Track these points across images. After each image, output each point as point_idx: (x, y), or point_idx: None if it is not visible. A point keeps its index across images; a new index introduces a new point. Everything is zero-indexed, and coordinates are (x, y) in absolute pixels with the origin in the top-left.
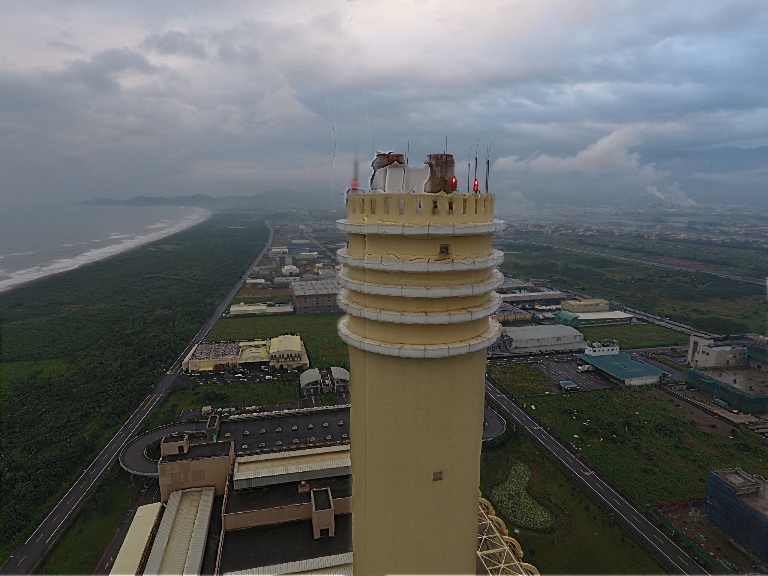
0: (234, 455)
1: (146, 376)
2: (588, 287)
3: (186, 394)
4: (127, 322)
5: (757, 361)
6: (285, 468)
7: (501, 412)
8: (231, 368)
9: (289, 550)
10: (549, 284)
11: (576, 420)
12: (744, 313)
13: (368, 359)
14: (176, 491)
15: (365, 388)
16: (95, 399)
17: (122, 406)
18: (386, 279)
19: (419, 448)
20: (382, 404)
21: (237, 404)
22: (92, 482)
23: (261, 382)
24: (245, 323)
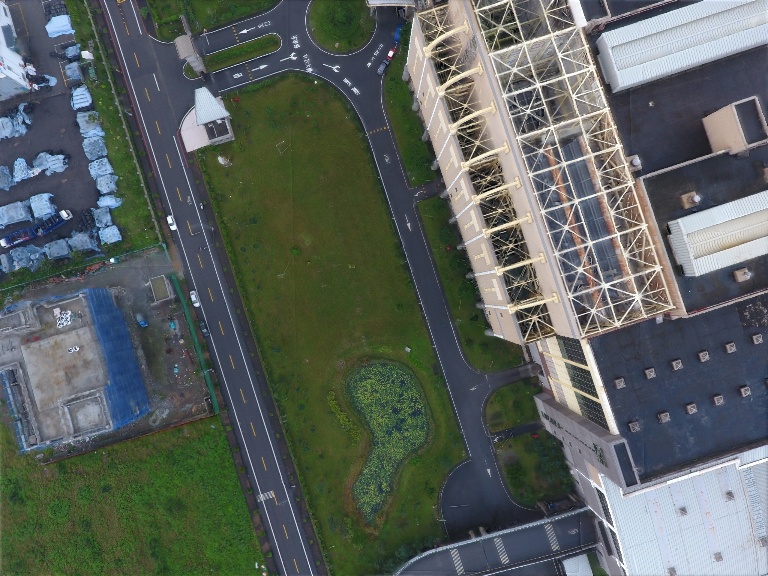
0: None
1: None
2: None
3: None
4: None
5: None
6: None
7: None
8: None
9: (750, 94)
10: None
11: None
12: None
13: None
14: None
15: None
16: None
17: None
18: None
19: None
20: None
21: None
22: None
23: None
24: None
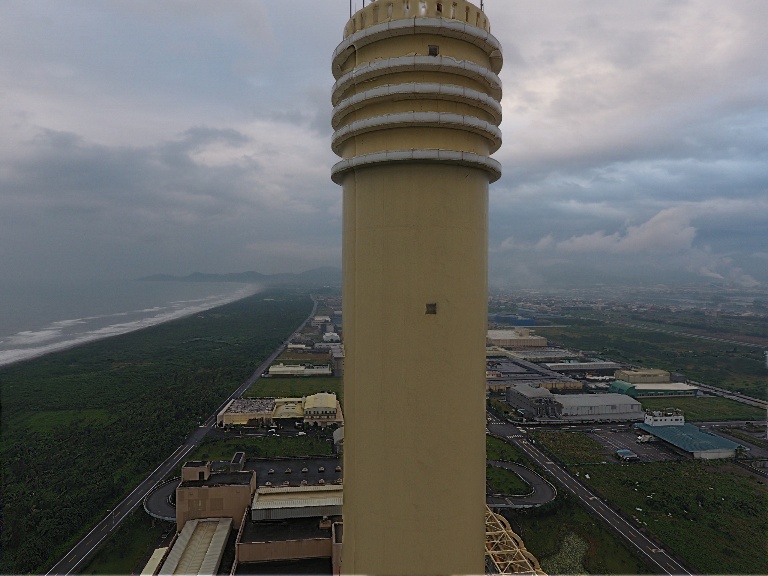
0: (255, 488)
1: (181, 427)
2: (645, 360)
3: (218, 446)
4: (170, 379)
5: None
6: (307, 501)
7: (550, 479)
8: (265, 423)
9: None
10: (601, 356)
11: (638, 492)
12: None
13: (357, 183)
14: (192, 520)
15: (355, 219)
16: (129, 445)
17: (154, 453)
18: None
19: (410, 274)
20: (371, 228)
21: None
22: (114, 525)
23: (294, 438)
24: (283, 383)
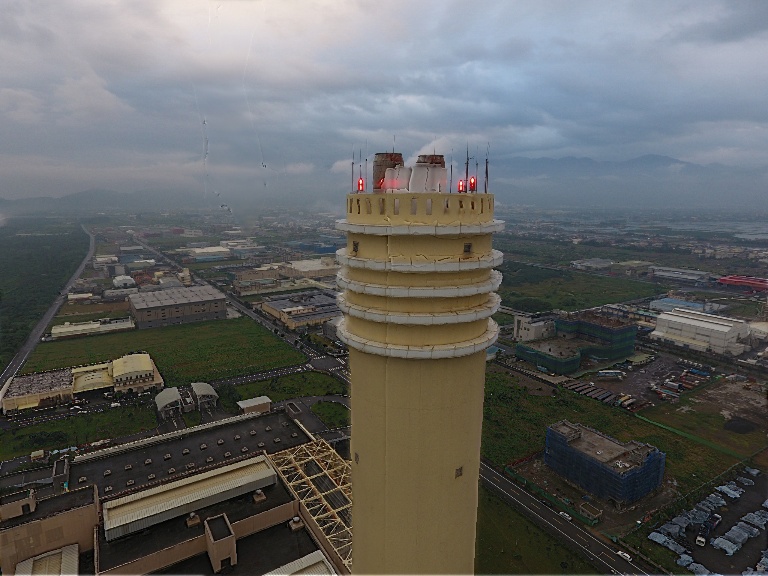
0: (98, 501)
1: None
2: None
3: (4, 441)
4: None
5: (562, 331)
6: (168, 503)
7: None
8: (63, 401)
9: None
10: None
11: None
12: (547, 293)
13: (389, 365)
14: (24, 561)
15: (384, 396)
16: None
17: None
18: (412, 281)
19: (443, 448)
20: (406, 410)
21: (78, 442)
22: None
23: (106, 411)
24: (74, 346)
